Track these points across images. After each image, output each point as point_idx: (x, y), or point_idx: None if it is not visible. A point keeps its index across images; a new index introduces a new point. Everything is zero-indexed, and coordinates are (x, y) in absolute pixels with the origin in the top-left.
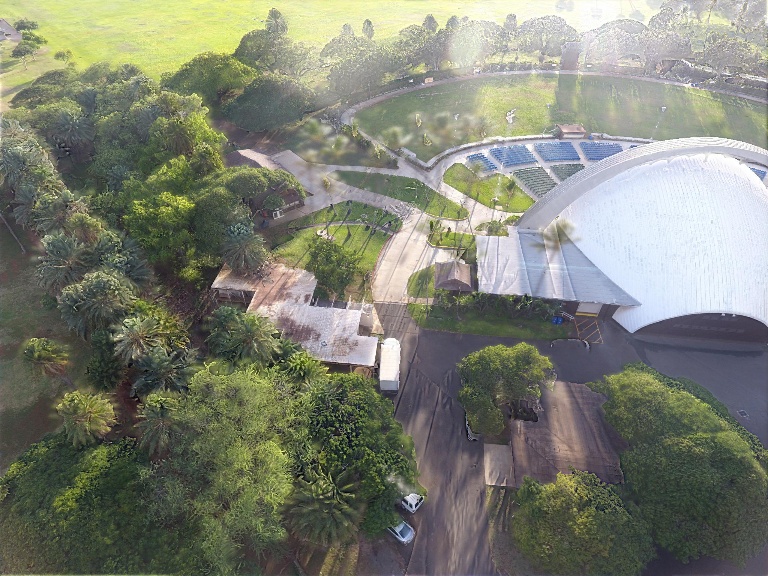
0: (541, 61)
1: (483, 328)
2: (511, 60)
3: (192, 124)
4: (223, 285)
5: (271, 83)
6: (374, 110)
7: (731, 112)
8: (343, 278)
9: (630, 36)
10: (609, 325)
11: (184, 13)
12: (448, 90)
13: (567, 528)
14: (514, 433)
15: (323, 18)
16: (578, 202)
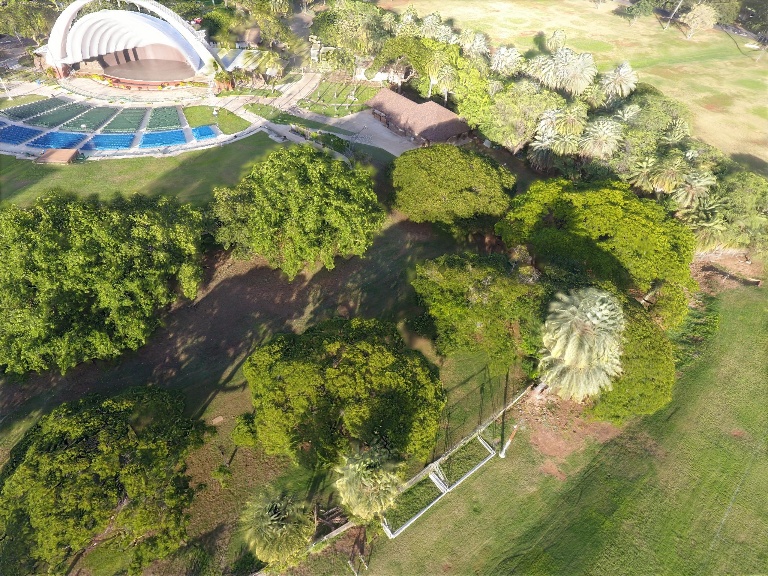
0: None
1: None
2: None
3: None
4: None
5: None
6: None
7: None
8: None
9: None
10: None
11: None
12: None
13: None
14: None
15: None
16: None
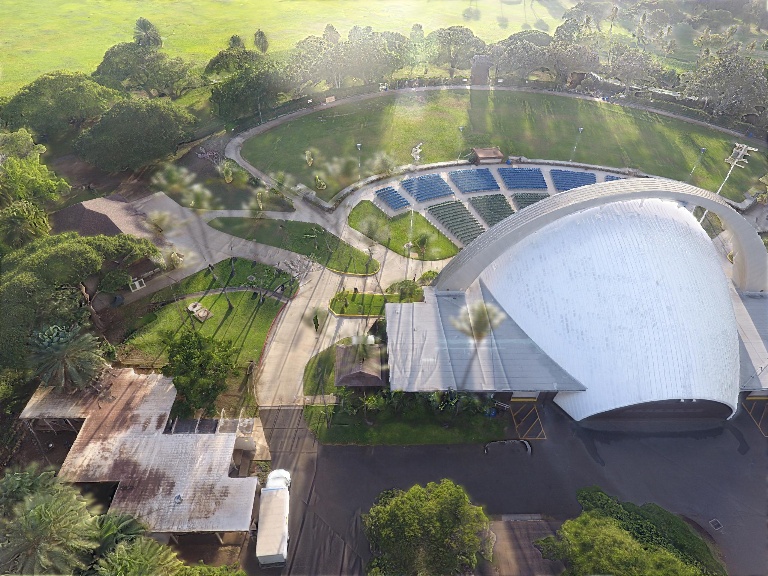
0: (451, 74)
1: (400, 434)
2: (420, 73)
3: (8, 174)
4: (38, 412)
5: (133, 110)
6: (266, 138)
7: (644, 128)
8: (209, 389)
9: (539, 49)
10: (550, 410)
11: (49, 21)
12: (352, 111)
13: None
14: None
15: (215, 27)
16: (502, 255)
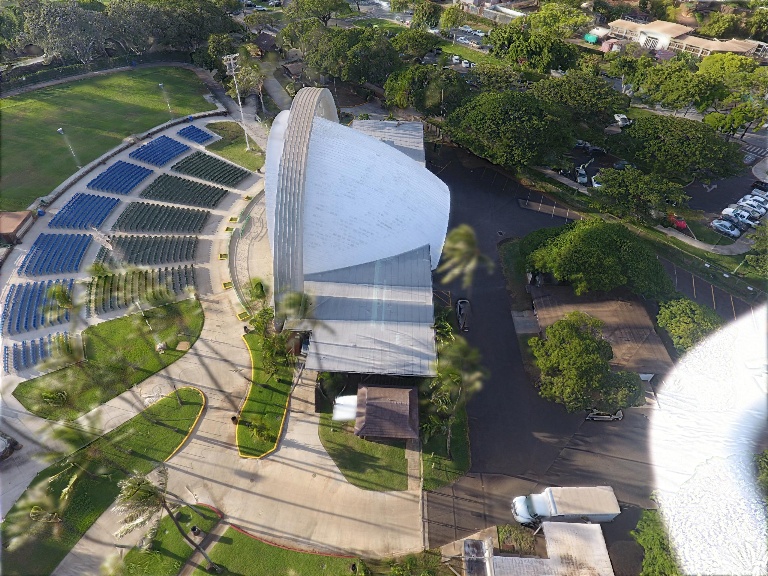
0: None
1: (453, 392)
2: None
3: None
4: None
5: None
6: None
7: (66, 104)
8: None
9: None
10: None
11: None
12: None
13: (719, 337)
14: (623, 369)
15: None
16: None
